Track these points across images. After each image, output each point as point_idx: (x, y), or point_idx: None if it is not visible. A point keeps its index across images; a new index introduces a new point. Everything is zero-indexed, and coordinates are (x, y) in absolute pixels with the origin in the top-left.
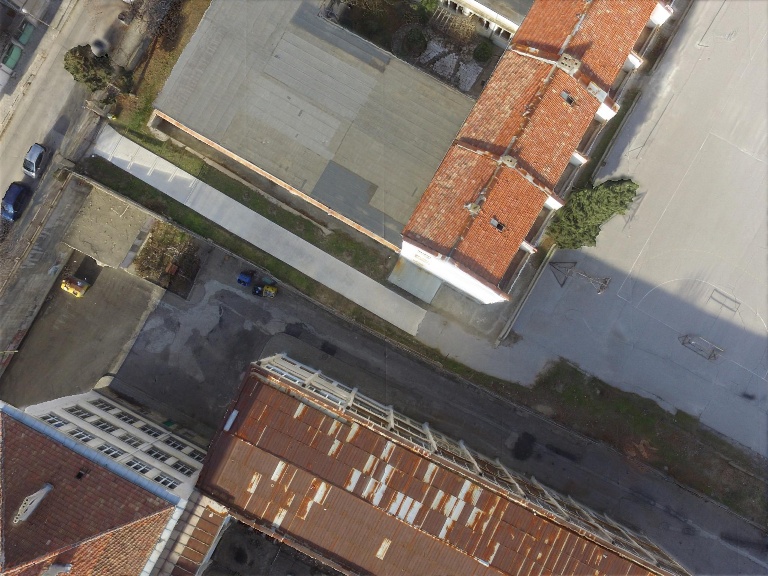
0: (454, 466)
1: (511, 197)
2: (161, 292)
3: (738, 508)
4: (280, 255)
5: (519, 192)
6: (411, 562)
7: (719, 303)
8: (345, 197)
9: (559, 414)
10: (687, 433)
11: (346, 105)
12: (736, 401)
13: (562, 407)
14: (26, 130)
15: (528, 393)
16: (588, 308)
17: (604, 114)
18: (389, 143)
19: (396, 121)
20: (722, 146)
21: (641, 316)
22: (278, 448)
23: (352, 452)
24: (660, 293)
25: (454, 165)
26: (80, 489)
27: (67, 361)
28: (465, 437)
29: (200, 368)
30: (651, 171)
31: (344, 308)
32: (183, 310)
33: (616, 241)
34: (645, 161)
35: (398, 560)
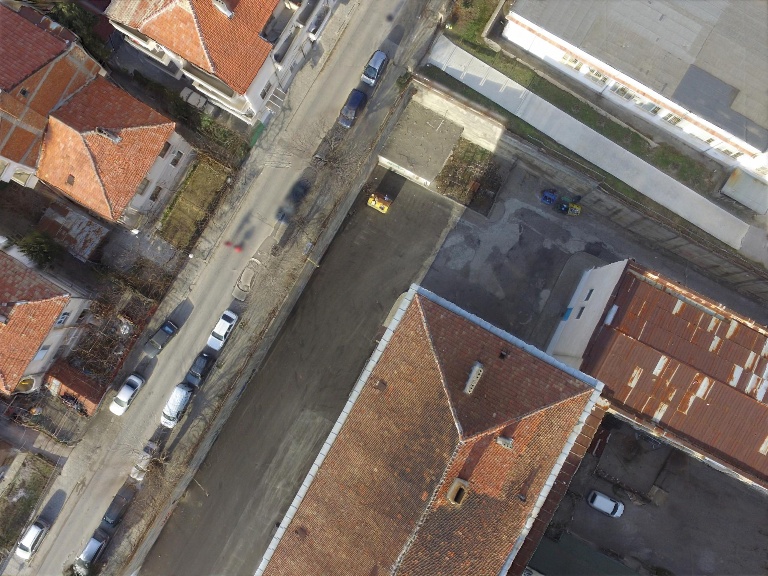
0: None
1: None
2: (461, 210)
3: None
4: (607, 167)
5: None
6: None
7: None
8: (706, 101)
9: None
10: None
11: (707, 10)
12: None
13: None
14: (360, 39)
15: None
16: None
17: None
18: (751, 48)
19: (757, 26)
20: None
21: None
22: (659, 343)
23: (732, 348)
24: None
25: None
26: (506, 368)
27: (368, 276)
28: None
29: (500, 285)
30: None
31: None
32: (483, 228)
33: None
34: None
35: None
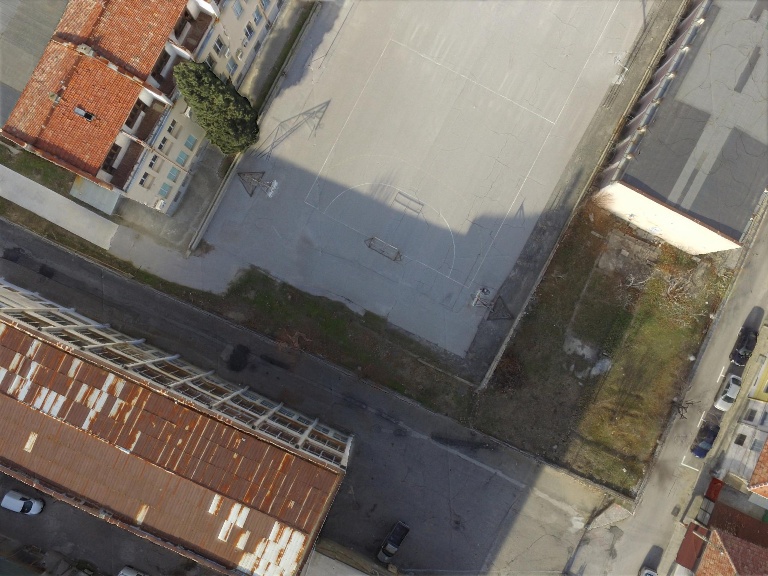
0: (97, 360)
1: (97, 86)
2: None
3: (432, 404)
4: None
5: (106, 81)
6: (58, 453)
7: (403, 206)
8: None
9: (250, 320)
10: (375, 333)
11: None
12: (422, 300)
13: (254, 313)
14: None
15: (221, 301)
16: (277, 216)
17: (207, 7)
18: (38, 53)
19: (45, 32)
20: (402, 52)
21: (329, 222)
22: None
23: None
24: (346, 198)
25: (48, 59)
26: None
27: None
28: (181, 351)
29: None
30: (334, 80)
31: (35, 225)
32: None
33: (303, 150)
34: (328, 70)
35: (45, 452)
